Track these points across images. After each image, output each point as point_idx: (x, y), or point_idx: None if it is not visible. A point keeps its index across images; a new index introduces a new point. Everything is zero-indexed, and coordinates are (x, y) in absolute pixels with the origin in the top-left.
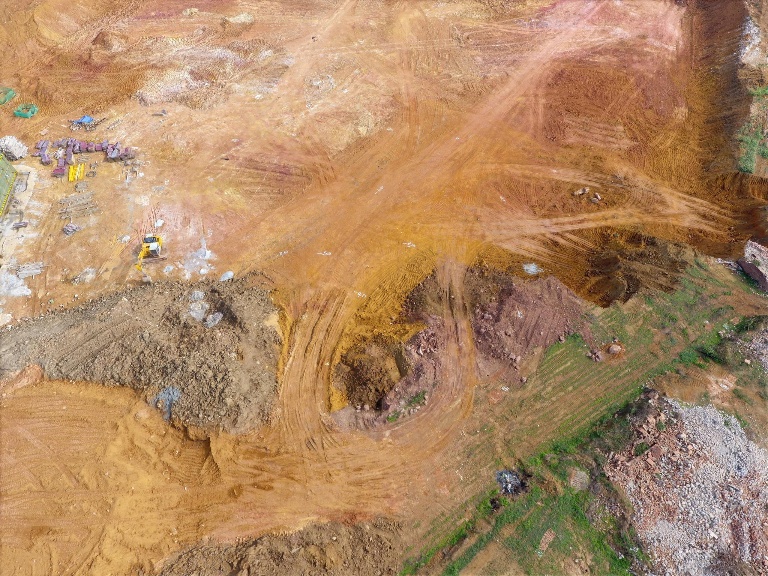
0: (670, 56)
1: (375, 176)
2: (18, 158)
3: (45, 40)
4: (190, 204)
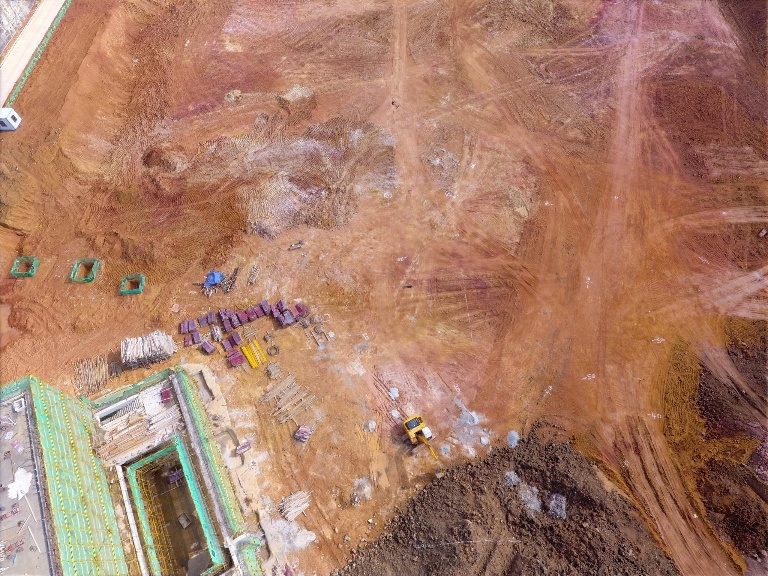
0: (737, 55)
1: (573, 266)
2: (171, 355)
3: (84, 175)
4: (411, 357)
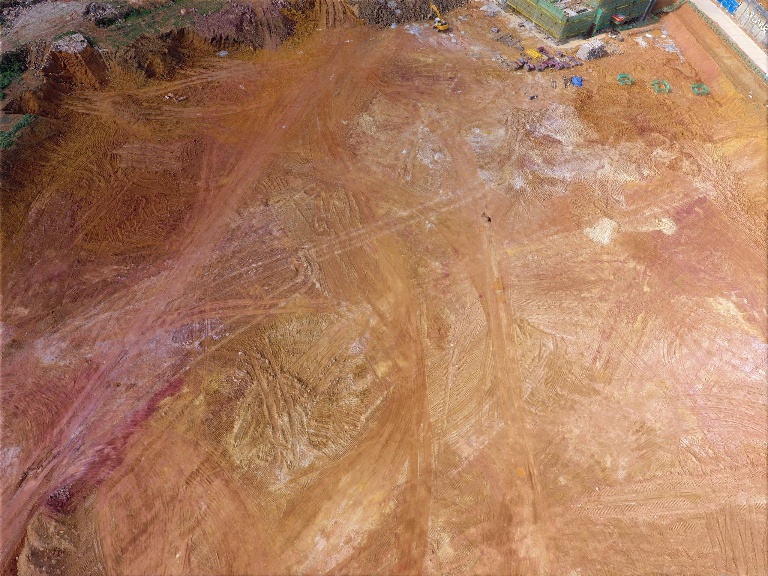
0: None
1: (339, 84)
2: None
3: None
4: (447, 51)
